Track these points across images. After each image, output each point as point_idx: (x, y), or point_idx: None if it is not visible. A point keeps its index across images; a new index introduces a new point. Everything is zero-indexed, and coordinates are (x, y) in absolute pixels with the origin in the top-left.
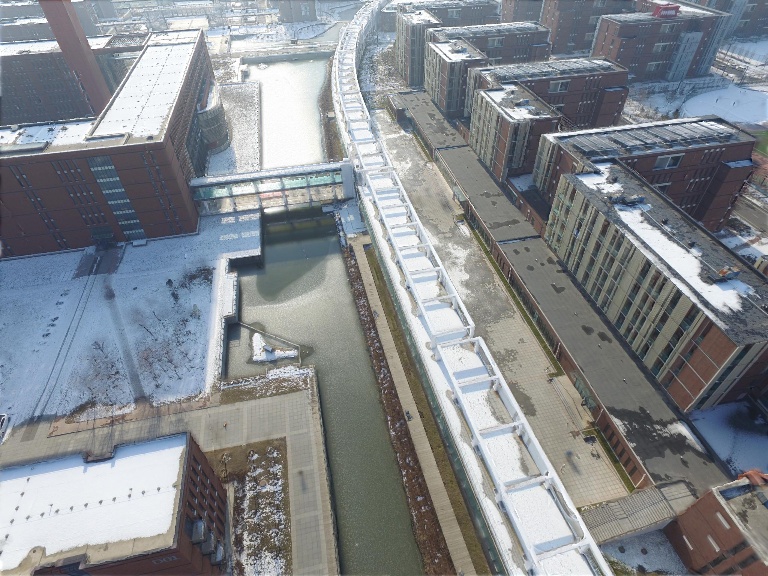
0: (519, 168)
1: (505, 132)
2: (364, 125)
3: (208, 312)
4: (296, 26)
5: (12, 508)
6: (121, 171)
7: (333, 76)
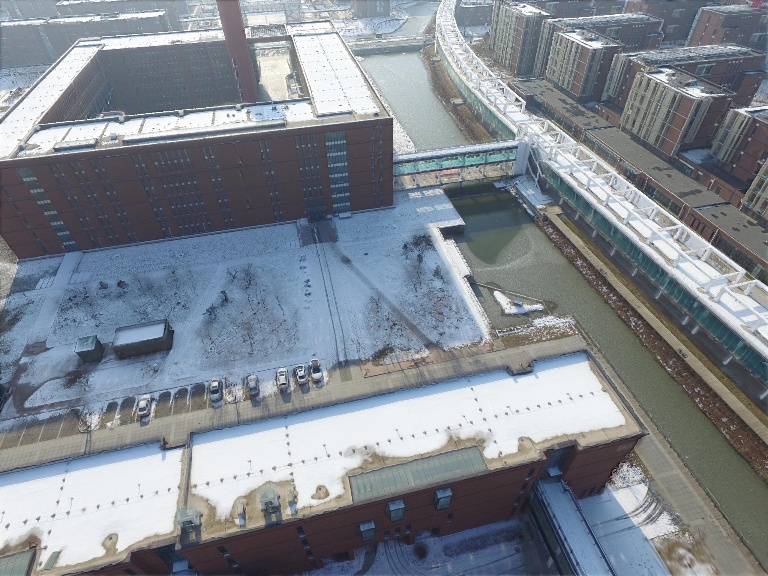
0: (688, 143)
1: (686, 109)
2: (514, 108)
3: (447, 273)
4: (373, 21)
5: (476, 410)
6: (350, 145)
7: (454, 65)
